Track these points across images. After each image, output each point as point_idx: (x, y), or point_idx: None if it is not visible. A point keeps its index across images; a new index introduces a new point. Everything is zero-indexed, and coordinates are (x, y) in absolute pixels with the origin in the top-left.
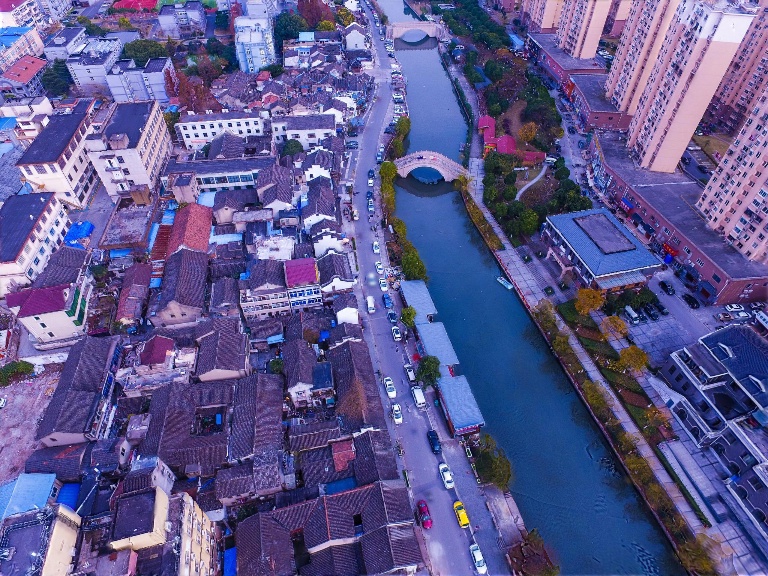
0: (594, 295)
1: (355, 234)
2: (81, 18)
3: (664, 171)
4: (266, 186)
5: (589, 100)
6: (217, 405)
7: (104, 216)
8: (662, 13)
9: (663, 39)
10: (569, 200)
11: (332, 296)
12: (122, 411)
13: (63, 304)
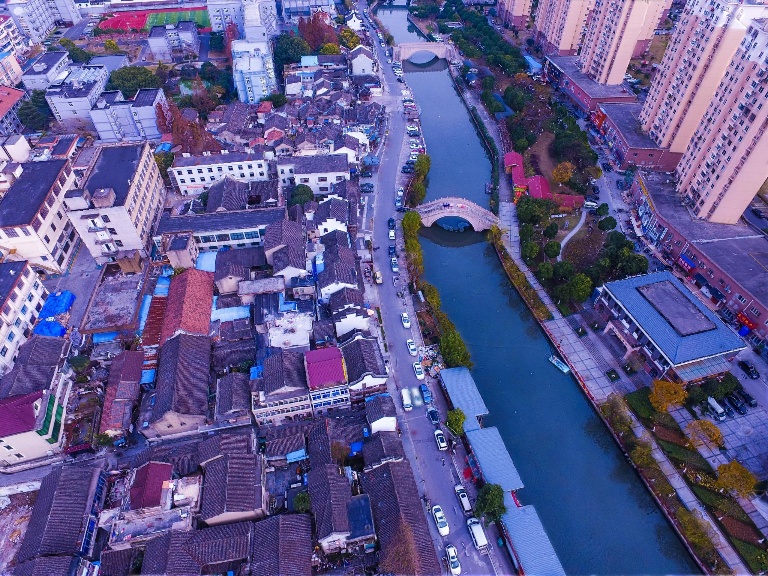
0: (675, 390)
1: (379, 302)
2: (64, 41)
3: (725, 222)
4: (276, 247)
5: (625, 134)
6: (228, 560)
7: (87, 282)
8: (715, 44)
9: (715, 72)
10: (623, 259)
11: (362, 394)
12: (107, 570)
13: (33, 422)
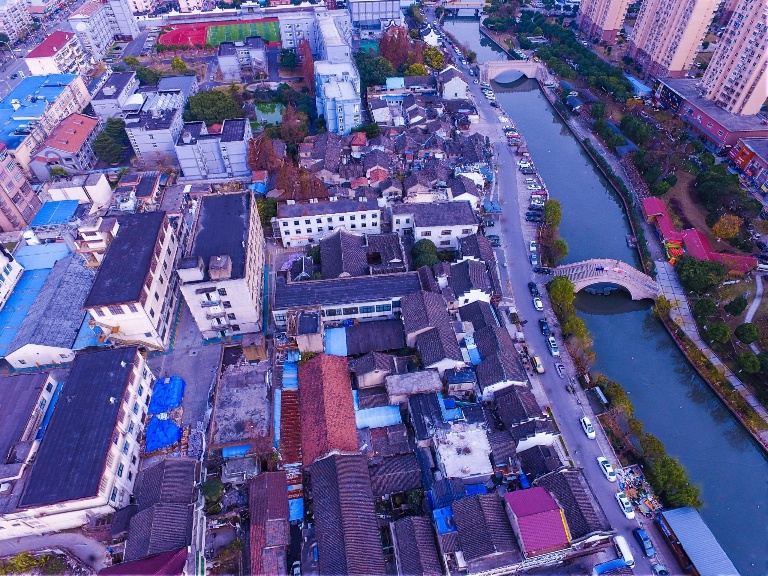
0: None
1: (547, 399)
2: (129, 59)
3: None
4: (421, 329)
5: None
6: None
7: (196, 363)
8: None
9: None
10: None
11: None
12: None
13: None
